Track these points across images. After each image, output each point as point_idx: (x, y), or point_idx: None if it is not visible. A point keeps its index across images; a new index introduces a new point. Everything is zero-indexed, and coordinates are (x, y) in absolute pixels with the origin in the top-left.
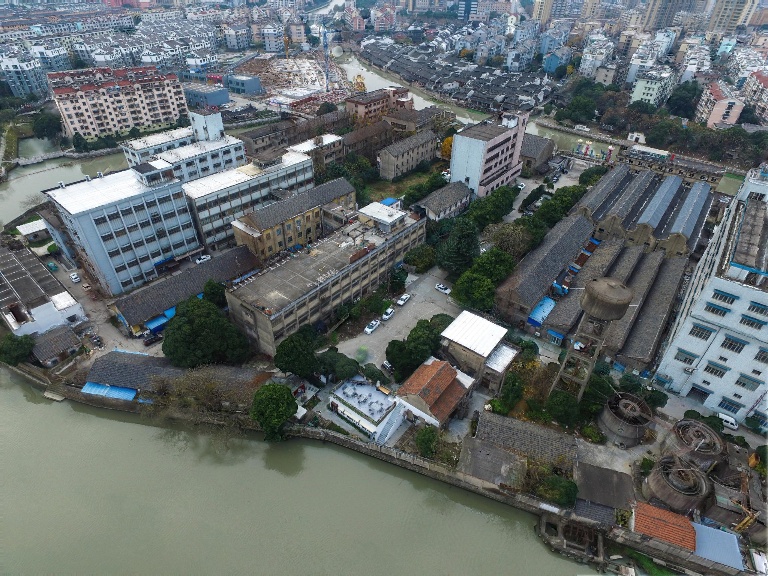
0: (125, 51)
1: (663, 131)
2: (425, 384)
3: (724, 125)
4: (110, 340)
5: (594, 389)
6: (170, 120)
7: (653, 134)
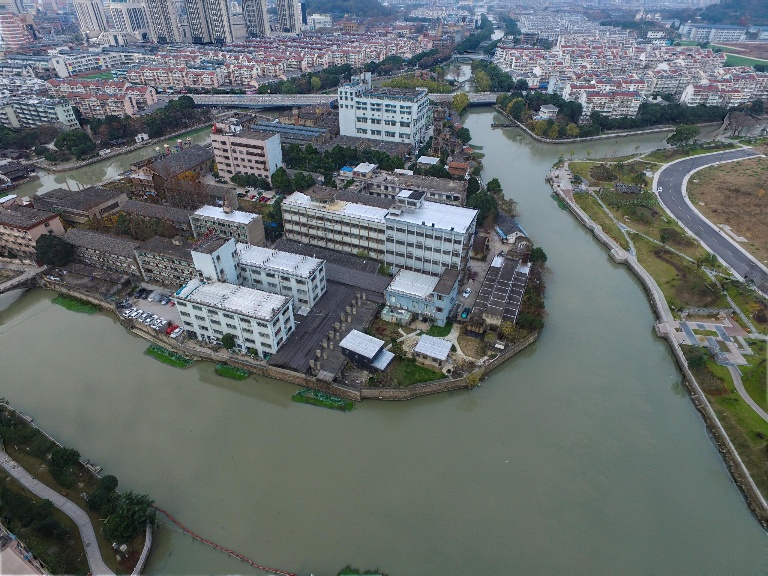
0: None
1: (157, 124)
2: None
3: (140, 112)
4: (496, 253)
5: None
6: None
7: (153, 129)
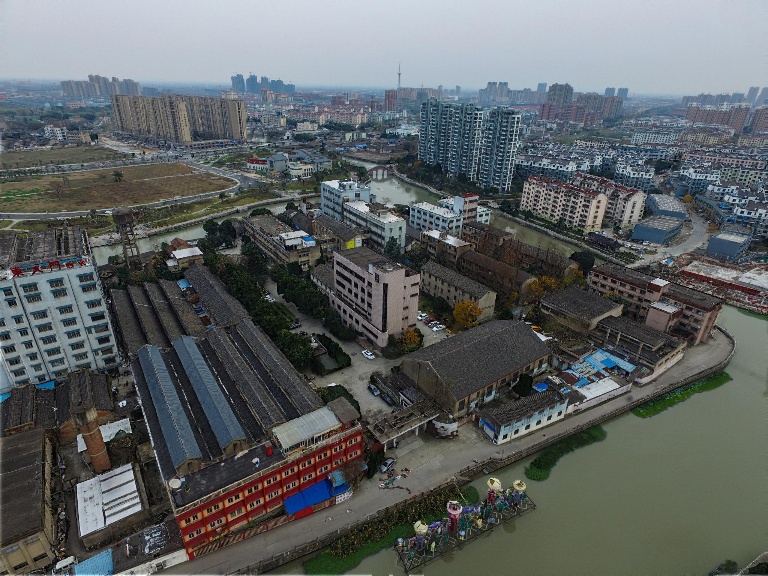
0: (766, 193)
1: None
2: (178, 239)
3: None
4: None
5: (123, 266)
6: (572, 223)
7: None
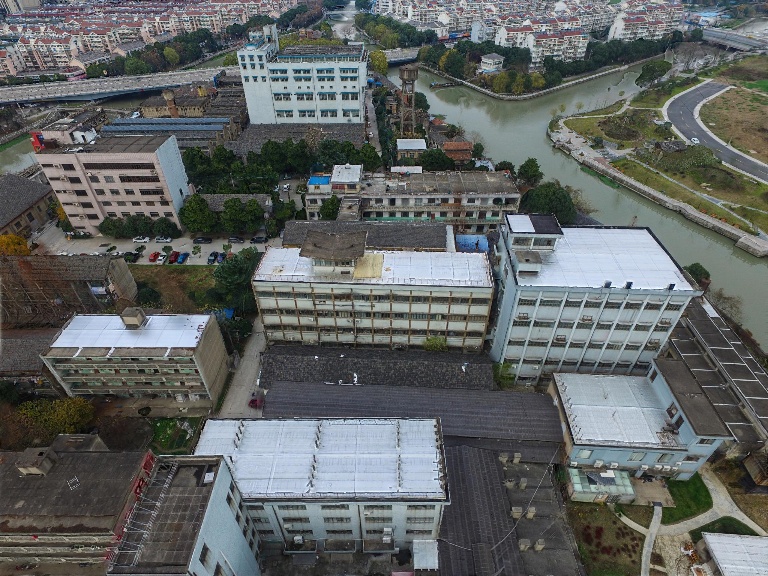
0: None
1: None
2: (464, 142)
3: None
4: None
5: None
6: None
7: None
